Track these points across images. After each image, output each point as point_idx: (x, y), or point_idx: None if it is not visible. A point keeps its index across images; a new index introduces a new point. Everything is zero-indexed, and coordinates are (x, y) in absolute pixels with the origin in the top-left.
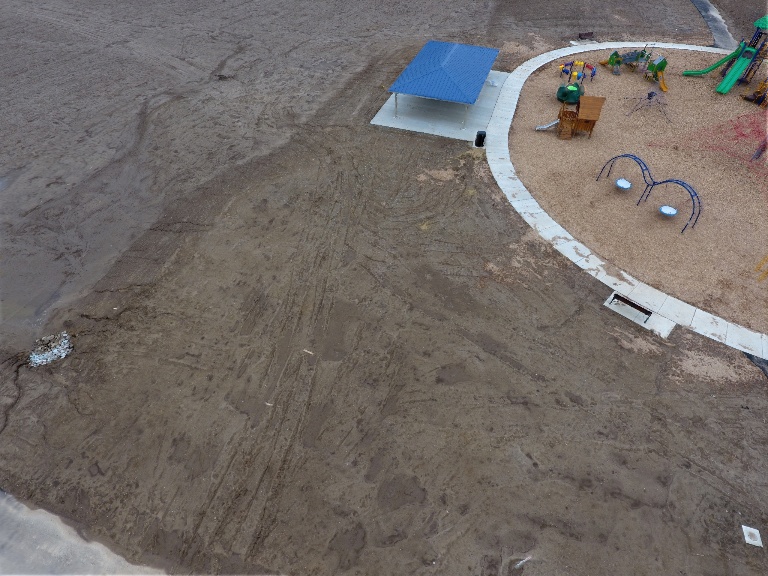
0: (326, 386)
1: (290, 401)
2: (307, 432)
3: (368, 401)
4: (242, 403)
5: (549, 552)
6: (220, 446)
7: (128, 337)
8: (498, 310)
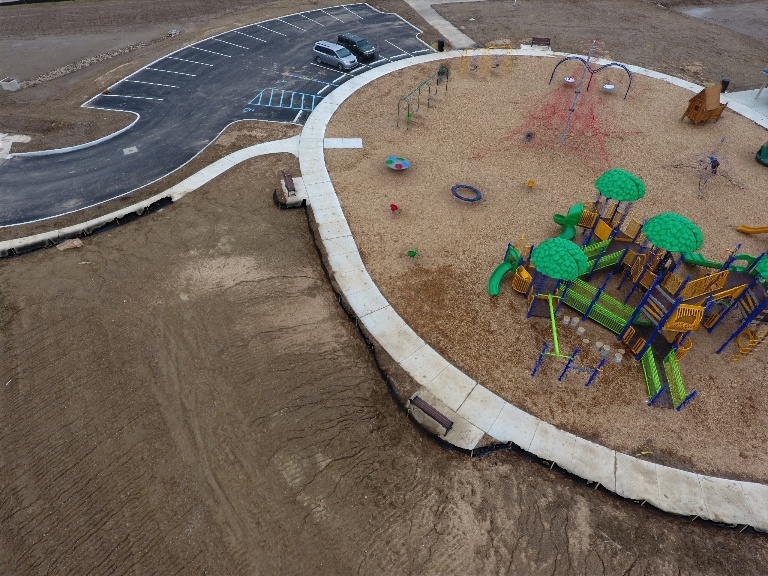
0: None
1: None
2: (580, 6)
3: None
4: (602, 5)
5: (511, 8)
6: (592, 1)
7: (653, 6)
8: (579, 33)
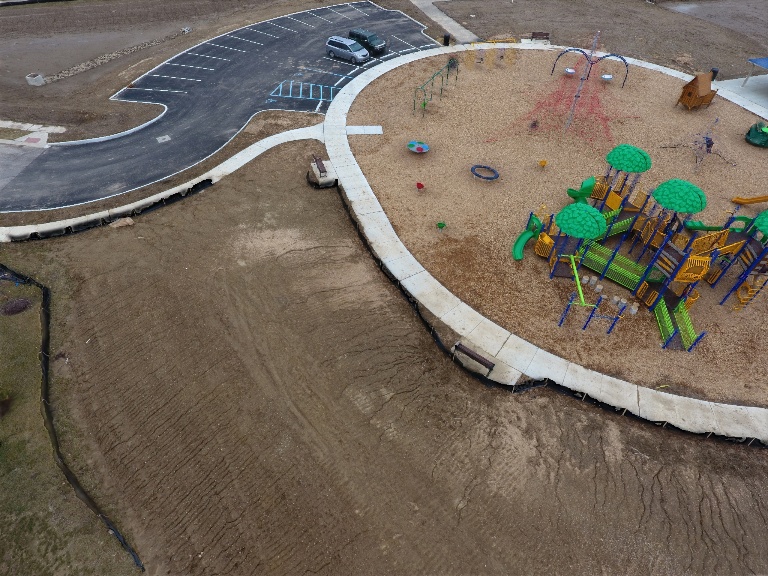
0: (585, 7)
1: (587, 4)
2: None
3: (572, 8)
4: None
5: (509, 5)
6: None
7: None
8: None
